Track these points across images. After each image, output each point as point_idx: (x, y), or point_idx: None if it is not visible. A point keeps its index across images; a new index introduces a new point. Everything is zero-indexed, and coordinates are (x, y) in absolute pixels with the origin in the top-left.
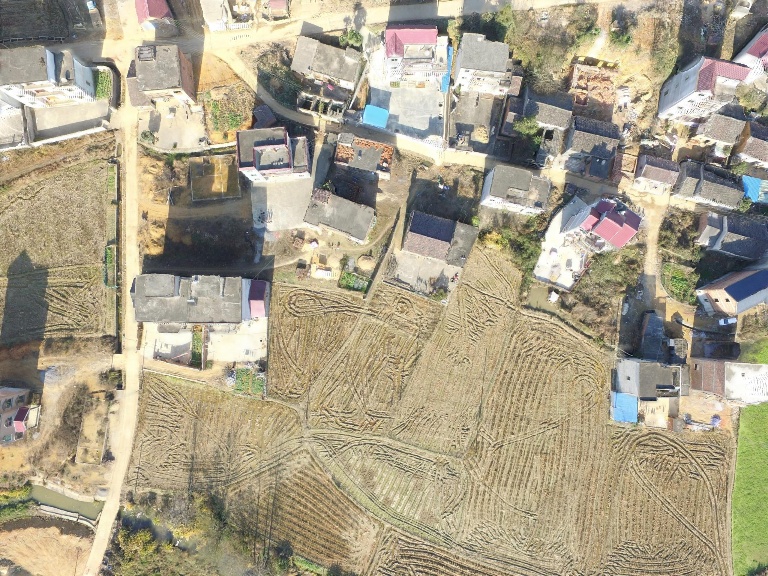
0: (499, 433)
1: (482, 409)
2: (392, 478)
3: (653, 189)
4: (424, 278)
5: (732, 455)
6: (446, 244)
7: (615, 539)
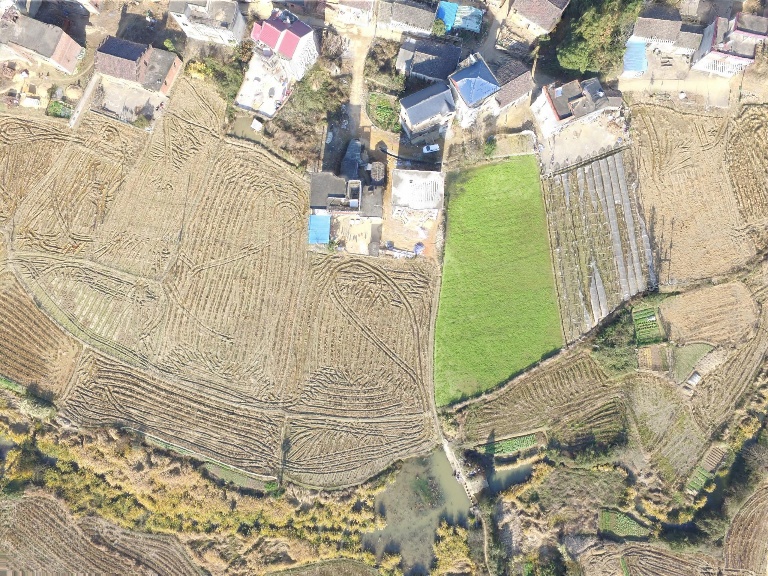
0: (199, 257)
1: (183, 234)
2: (92, 300)
3: (358, 20)
4: (130, 107)
5: (436, 283)
6: (133, 63)
7: (313, 365)
